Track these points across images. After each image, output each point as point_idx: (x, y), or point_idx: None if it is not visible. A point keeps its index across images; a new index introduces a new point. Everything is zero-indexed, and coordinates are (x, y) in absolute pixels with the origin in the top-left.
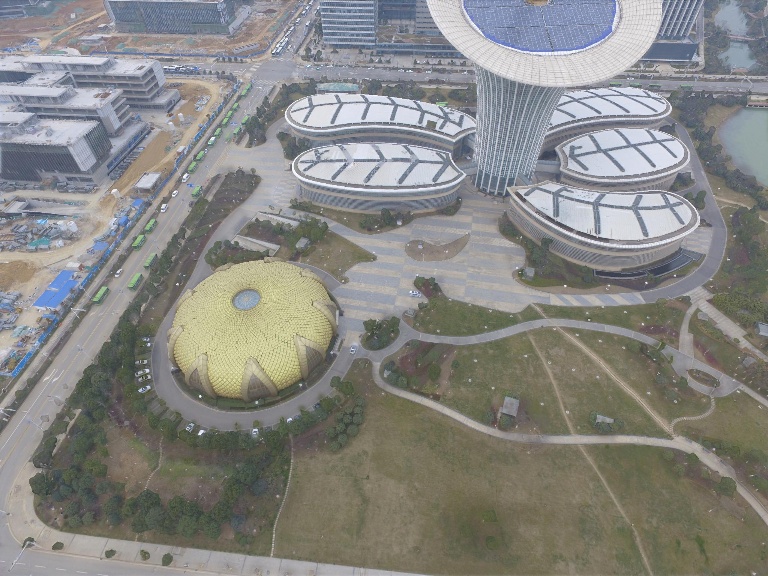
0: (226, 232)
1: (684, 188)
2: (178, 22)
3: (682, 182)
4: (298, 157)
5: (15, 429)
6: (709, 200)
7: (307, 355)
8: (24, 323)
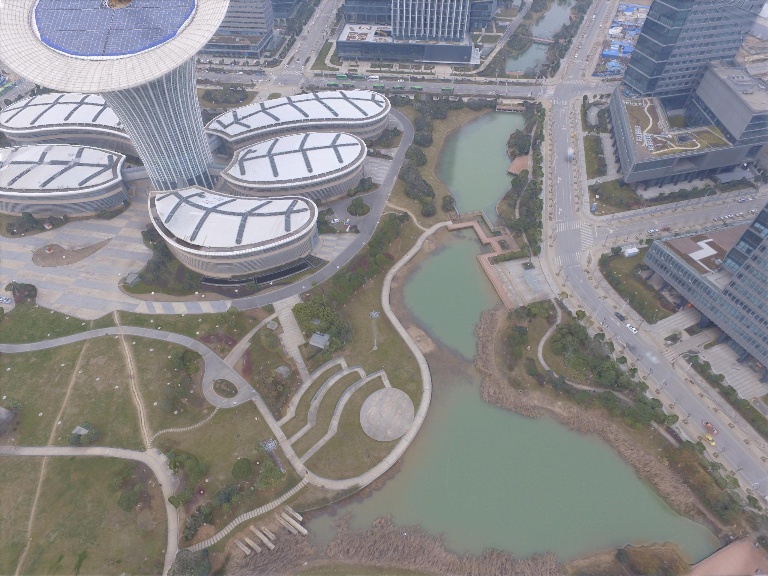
0: None
1: (363, 193)
2: None
3: (362, 187)
4: None
5: None
6: (378, 206)
7: None
8: None
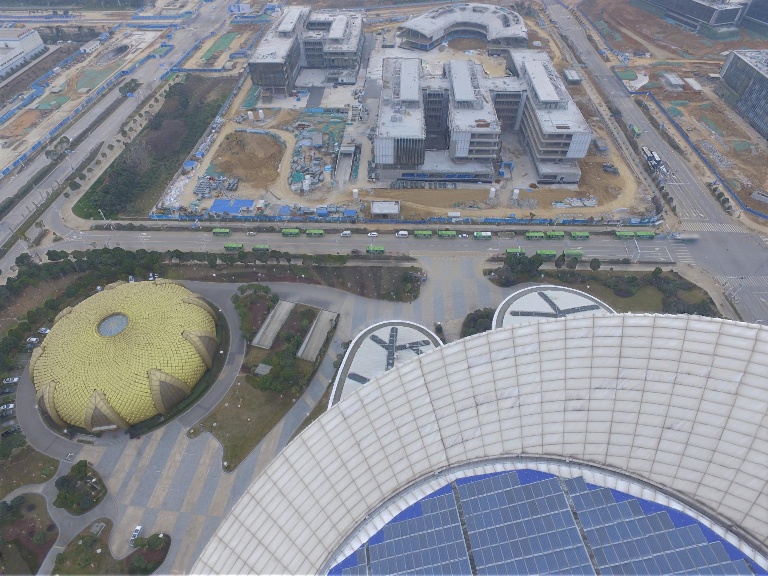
0: (303, 293)
1: None
2: None
3: None
4: (411, 324)
5: (104, 235)
6: None
7: None
8: (204, 203)
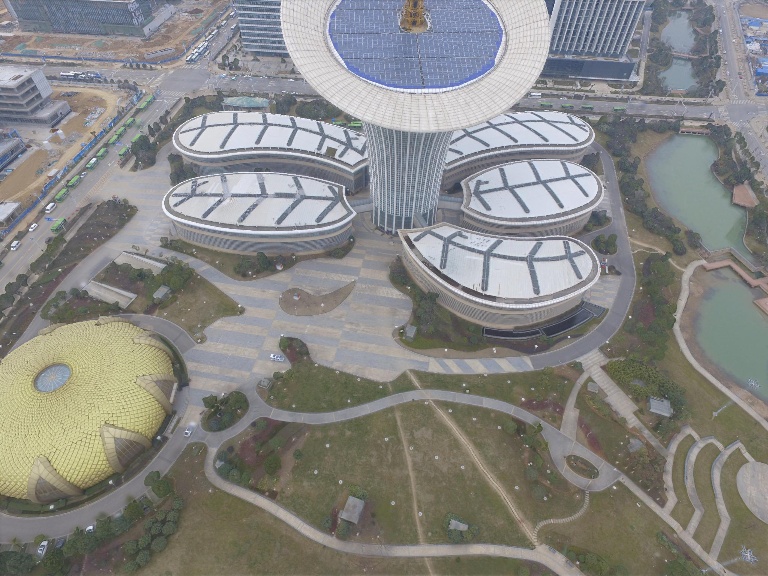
0: (80, 277)
1: (598, 228)
2: (87, 22)
3: (597, 221)
4: (173, 189)
5: None
6: (623, 243)
7: (117, 448)
8: None
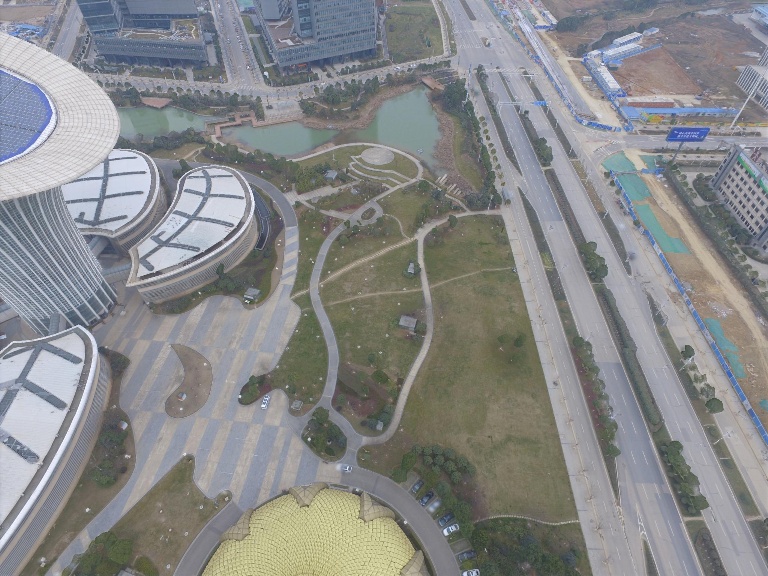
0: None
1: None
2: None
3: None
4: None
5: None
6: None
7: None
8: None
